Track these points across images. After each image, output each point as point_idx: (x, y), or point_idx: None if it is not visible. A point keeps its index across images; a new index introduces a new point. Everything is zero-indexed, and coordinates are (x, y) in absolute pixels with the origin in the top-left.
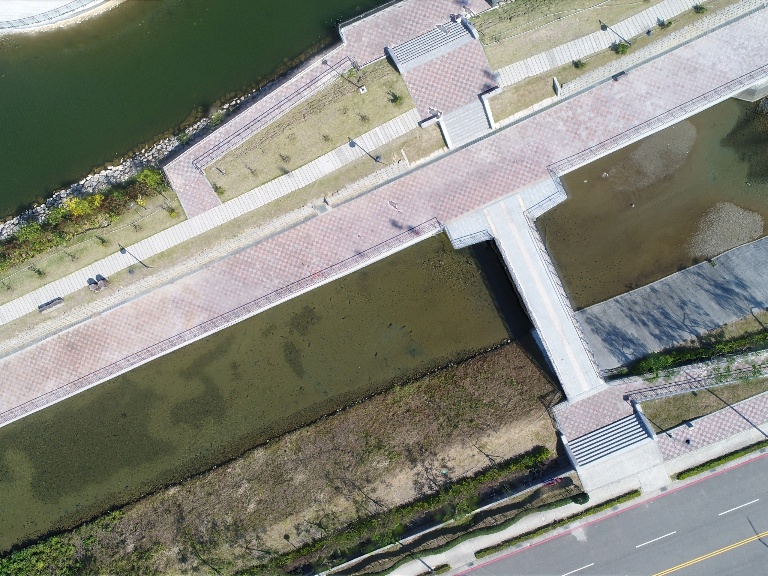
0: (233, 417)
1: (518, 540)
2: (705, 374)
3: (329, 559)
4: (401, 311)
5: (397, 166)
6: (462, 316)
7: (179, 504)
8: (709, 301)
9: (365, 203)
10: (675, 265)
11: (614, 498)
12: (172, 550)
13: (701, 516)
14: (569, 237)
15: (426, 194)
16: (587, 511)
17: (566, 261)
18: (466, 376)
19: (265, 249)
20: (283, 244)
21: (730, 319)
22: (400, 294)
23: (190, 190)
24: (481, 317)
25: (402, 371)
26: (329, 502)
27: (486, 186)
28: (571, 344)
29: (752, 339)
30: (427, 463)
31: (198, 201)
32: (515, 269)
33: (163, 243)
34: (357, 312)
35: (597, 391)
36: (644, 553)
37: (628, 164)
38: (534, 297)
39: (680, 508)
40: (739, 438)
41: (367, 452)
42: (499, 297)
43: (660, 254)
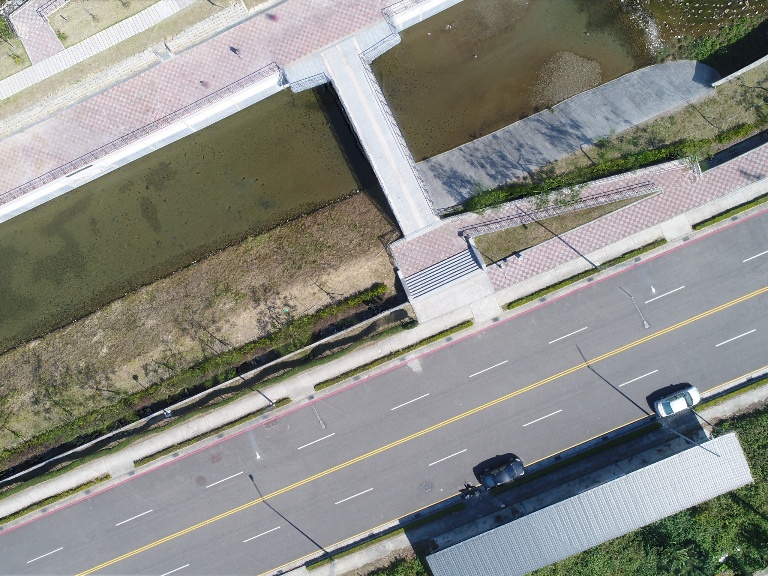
0: (93, 272)
1: (355, 371)
2: (535, 207)
3: (177, 398)
4: (253, 165)
5: (234, 10)
6: (312, 168)
7: (38, 355)
8: (544, 142)
9: (207, 49)
10: (517, 114)
11: (448, 329)
12: (27, 394)
13: (532, 345)
14: (414, 89)
15: (265, 39)
16: (421, 342)
17: (412, 112)
18: (314, 224)
19: (111, 96)
20: (128, 91)
21: (560, 155)
22: (252, 148)
23: (34, 37)
24: (331, 169)
25: (255, 223)
26: (175, 342)
27: (323, 30)
28: (407, 182)
29: (580, 172)
30: (270, 302)
31: (42, 47)
32: (352, 110)
33: (9, 89)
34: (211, 167)
35: (433, 228)
36: (477, 382)
37: (470, 16)
38: (370, 137)
39: (511, 337)
40: (567, 267)
41: (215, 296)
42: (348, 149)
43: (502, 103)
